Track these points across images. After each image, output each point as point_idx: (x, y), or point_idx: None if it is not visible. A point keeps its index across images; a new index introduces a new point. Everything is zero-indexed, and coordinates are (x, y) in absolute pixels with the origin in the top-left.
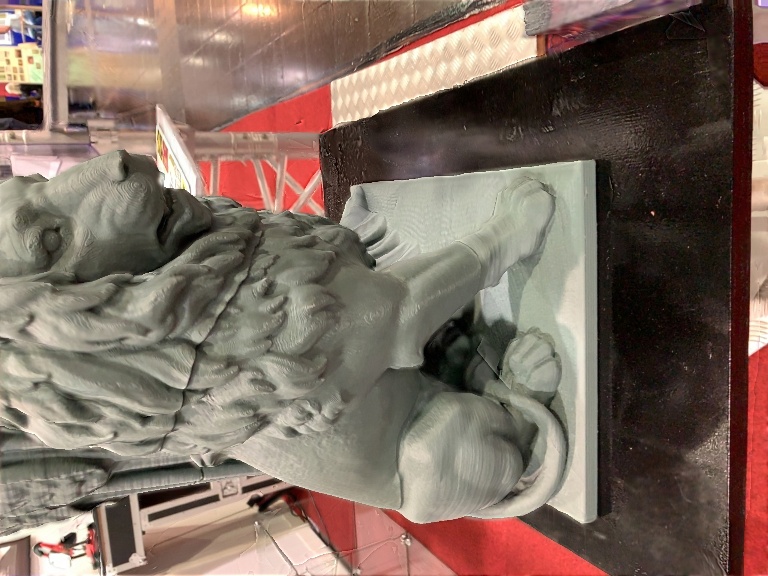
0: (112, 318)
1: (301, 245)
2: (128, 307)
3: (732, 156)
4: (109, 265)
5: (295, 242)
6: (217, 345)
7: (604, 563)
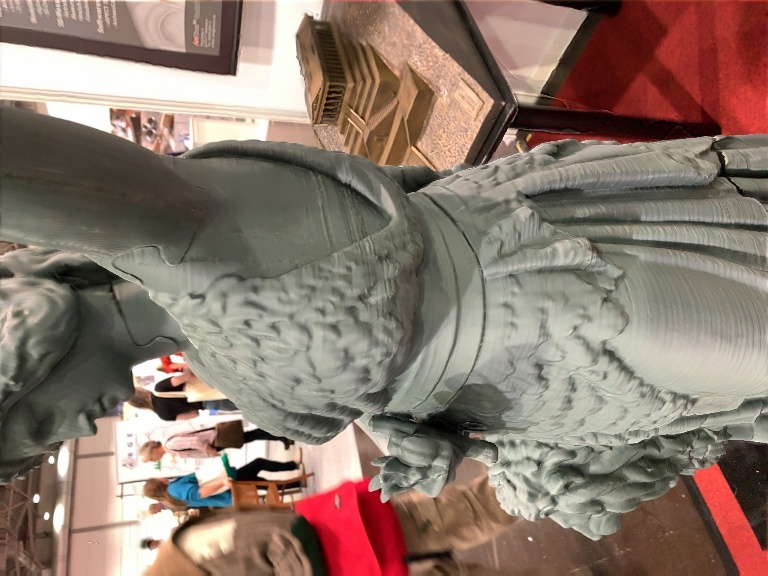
0: None
1: None
2: None
3: (743, 510)
4: None
5: None
6: None
7: None
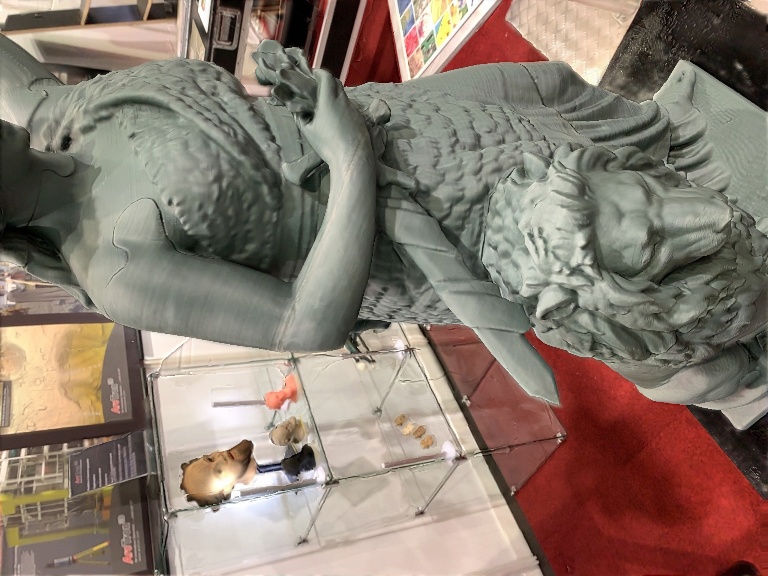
0: (664, 321)
1: (757, 269)
2: (675, 316)
3: None
4: (666, 273)
5: (756, 267)
6: (687, 334)
7: (730, 450)
